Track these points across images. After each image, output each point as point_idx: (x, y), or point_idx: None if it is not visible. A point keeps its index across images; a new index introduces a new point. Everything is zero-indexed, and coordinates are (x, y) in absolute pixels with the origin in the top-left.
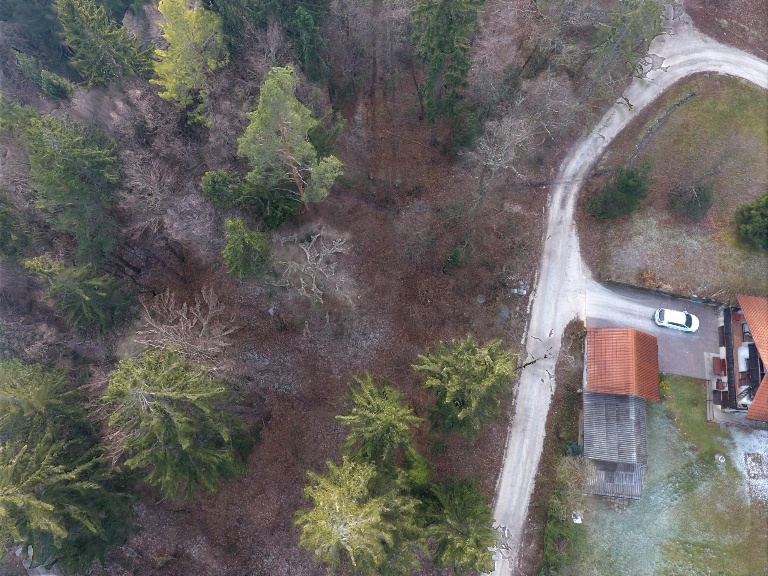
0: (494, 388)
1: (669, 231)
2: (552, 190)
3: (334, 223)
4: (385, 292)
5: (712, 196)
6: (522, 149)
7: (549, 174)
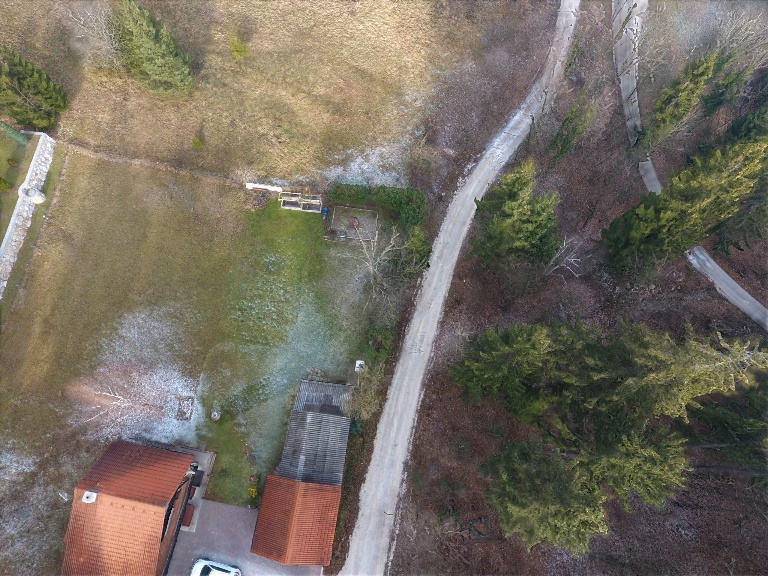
0: (558, 493)
1: None
2: None
3: None
4: None
5: None
6: None
7: None
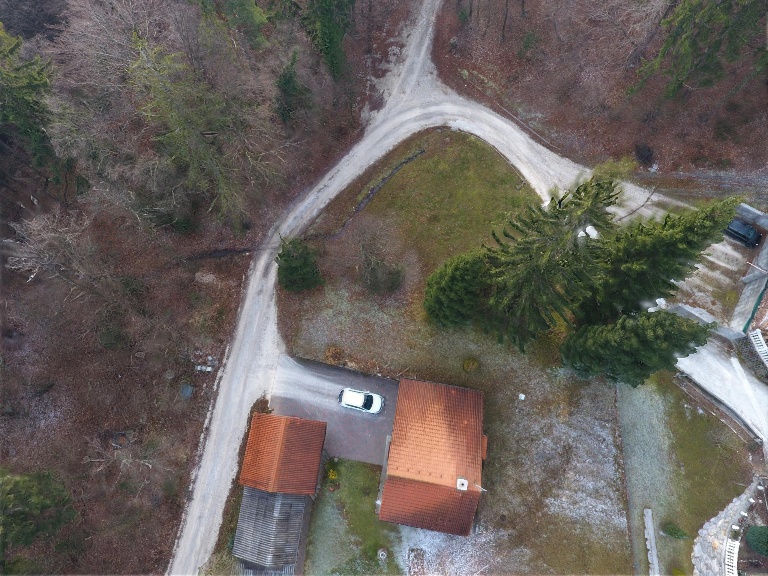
0: None
1: (360, 304)
2: (256, 257)
3: (22, 293)
4: (71, 367)
5: (380, 273)
6: (230, 212)
7: (255, 239)
